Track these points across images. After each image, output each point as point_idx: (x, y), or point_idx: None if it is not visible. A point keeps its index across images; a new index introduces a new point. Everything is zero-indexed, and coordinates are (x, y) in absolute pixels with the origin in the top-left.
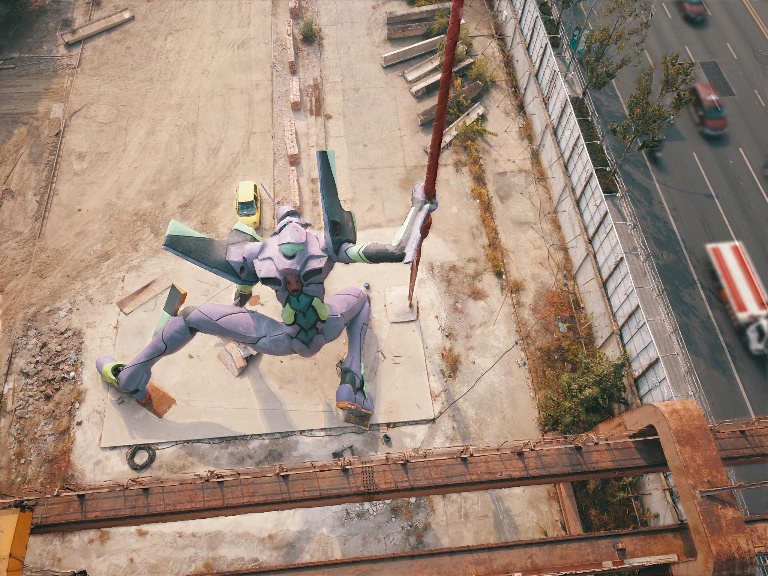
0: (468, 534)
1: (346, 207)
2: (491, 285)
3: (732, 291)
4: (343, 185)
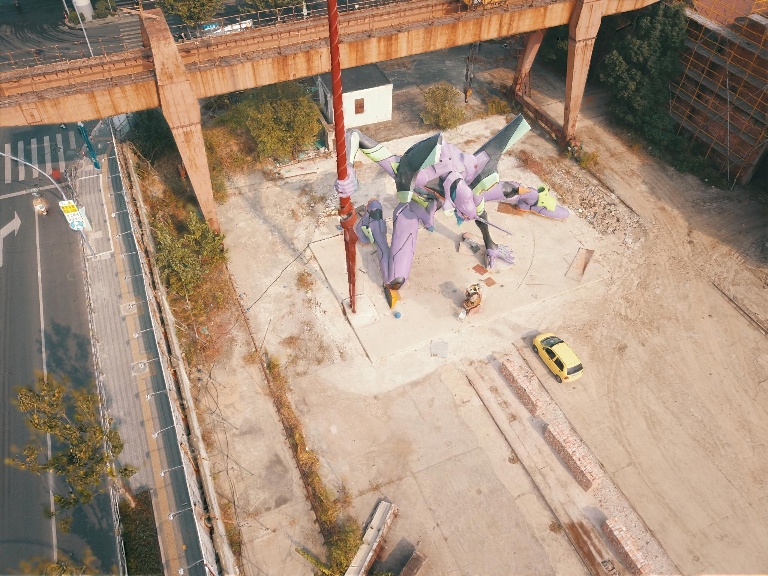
0: (273, 198)
1: (458, 395)
2: (278, 354)
3: (10, 407)
4: (476, 422)
